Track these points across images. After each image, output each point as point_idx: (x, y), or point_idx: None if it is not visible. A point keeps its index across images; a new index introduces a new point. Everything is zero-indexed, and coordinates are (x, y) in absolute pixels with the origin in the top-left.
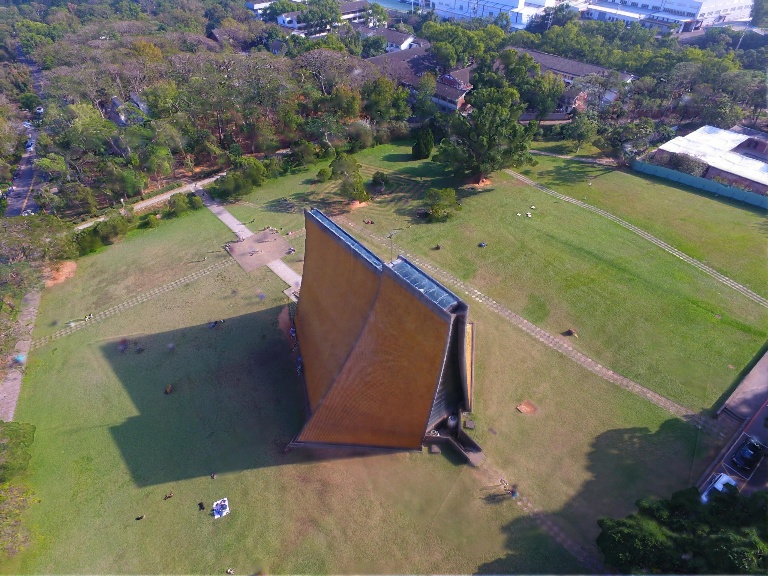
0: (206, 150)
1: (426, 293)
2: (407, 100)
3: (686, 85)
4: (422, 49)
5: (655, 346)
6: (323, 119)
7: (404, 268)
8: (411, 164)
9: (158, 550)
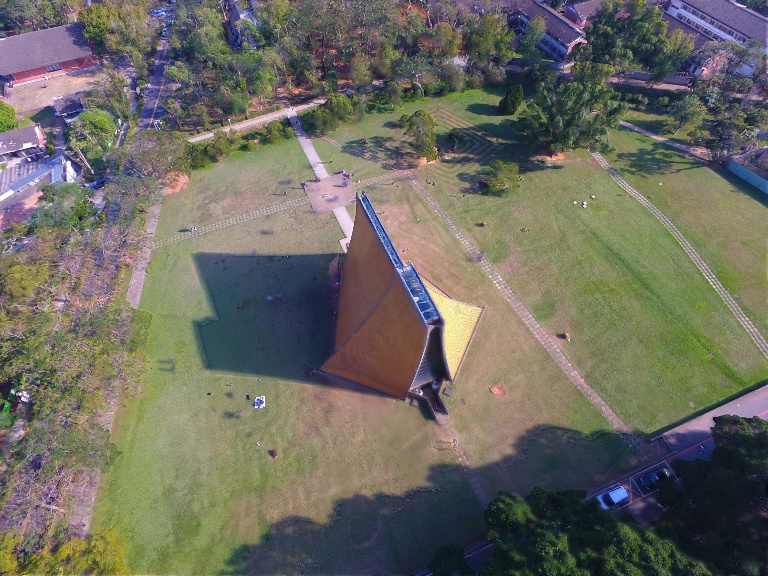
0: None
1: (421, 300)
2: (510, 43)
3: None
4: None
5: (634, 368)
6: (416, 61)
7: (413, 274)
8: (493, 120)
9: (218, 418)
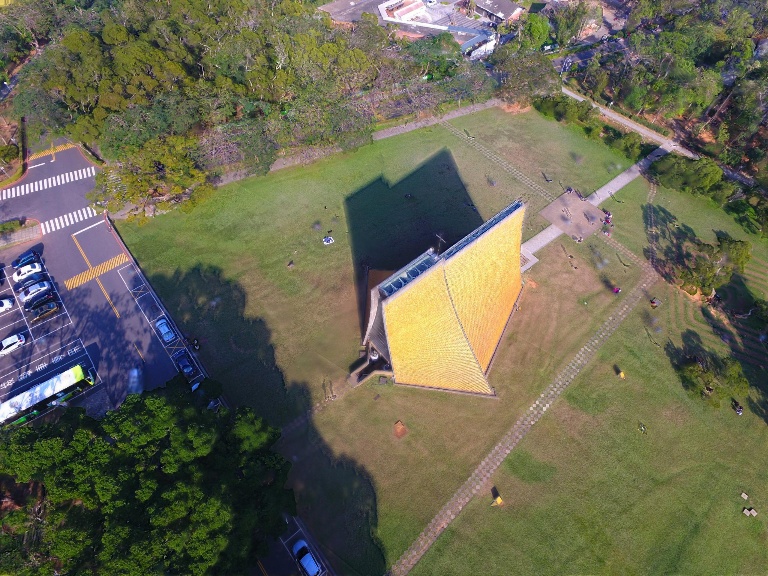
0: None
1: None
2: None
3: None
4: None
5: None
6: None
7: None
8: None
9: (309, 220)
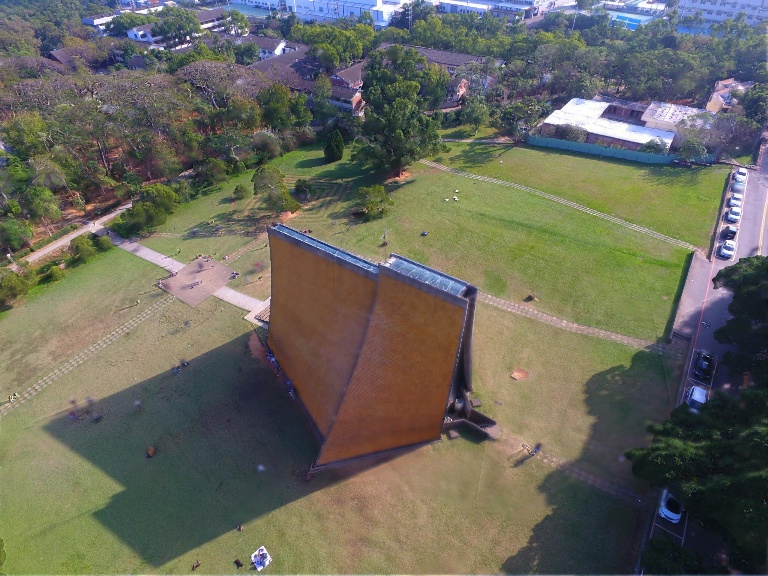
0: (94, 184)
1: None
2: (305, 104)
3: (549, 65)
4: (298, 53)
5: (602, 294)
6: (227, 133)
7: (398, 265)
8: (327, 167)
9: None
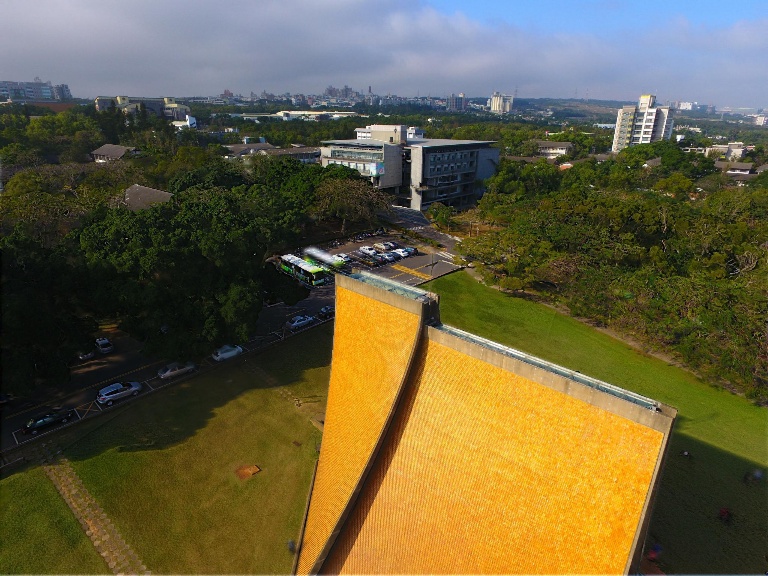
0: None
1: None
2: None
3: None
4: None
5: None
6: None
7: None
8: None
9: None
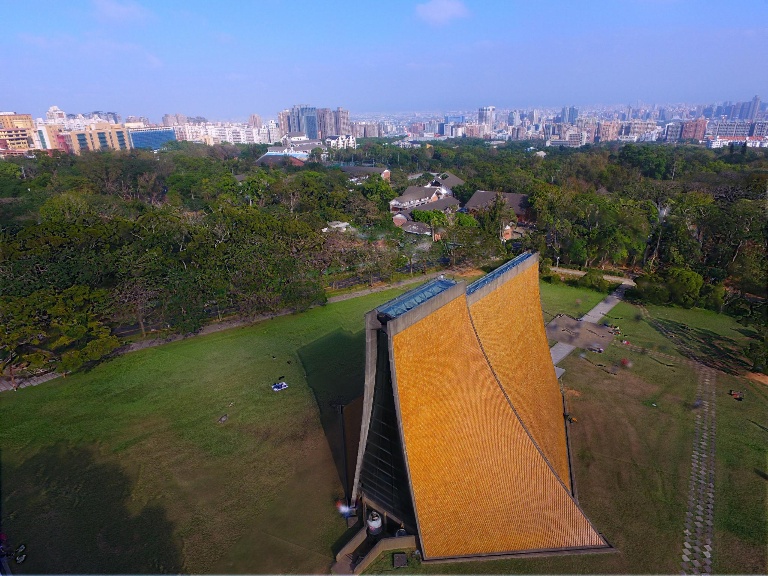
0: None
1: None
2: None
3: None
4: None
5: None
6: None
7: None
8: None
9: (251, 370)
